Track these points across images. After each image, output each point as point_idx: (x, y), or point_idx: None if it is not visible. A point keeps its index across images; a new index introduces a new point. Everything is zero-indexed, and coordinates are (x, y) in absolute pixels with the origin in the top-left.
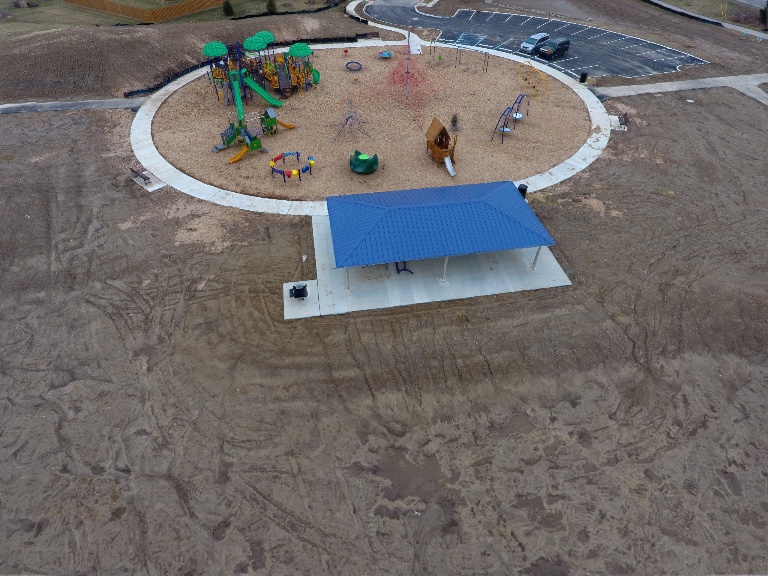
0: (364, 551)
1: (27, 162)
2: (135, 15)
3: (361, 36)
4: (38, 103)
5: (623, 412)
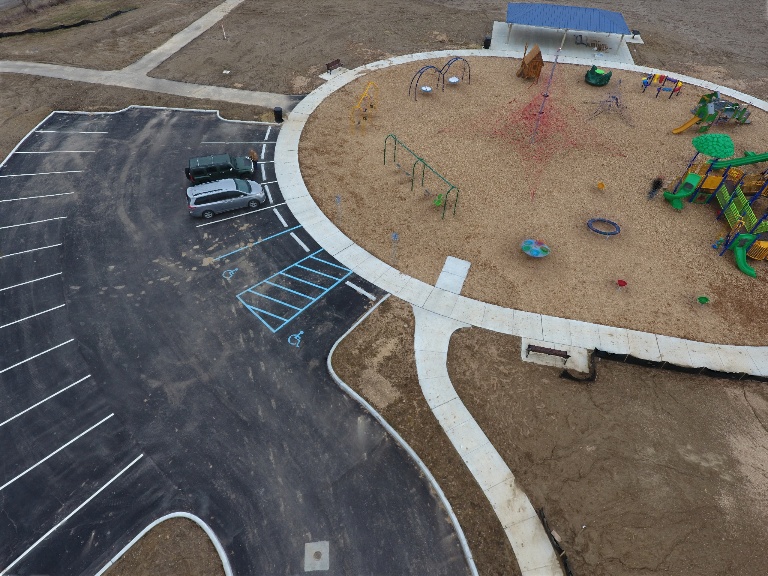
0: (601, 8)
1: None
2: None
3: (579, 381)
4: None
5: None
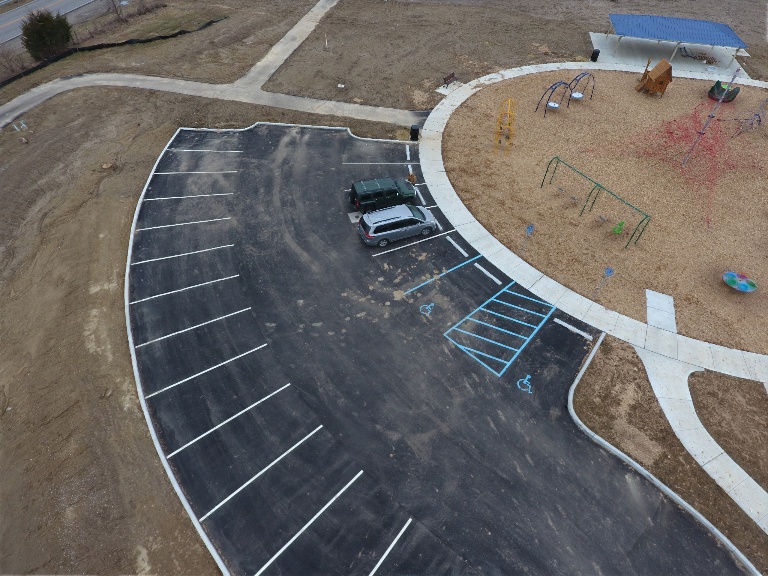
0: None
1: None
2: None
3: None
4: None
5: None
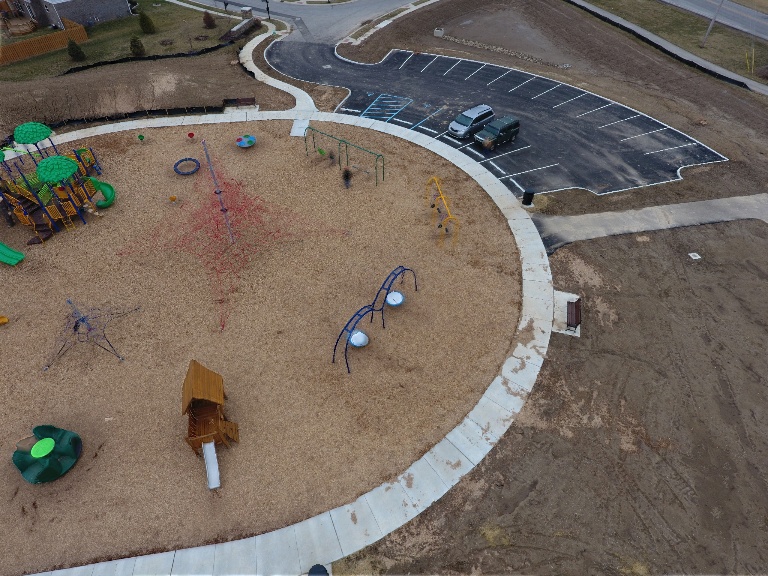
0: None
1: None
2: None
3: (232, 102)
4: None
5: None
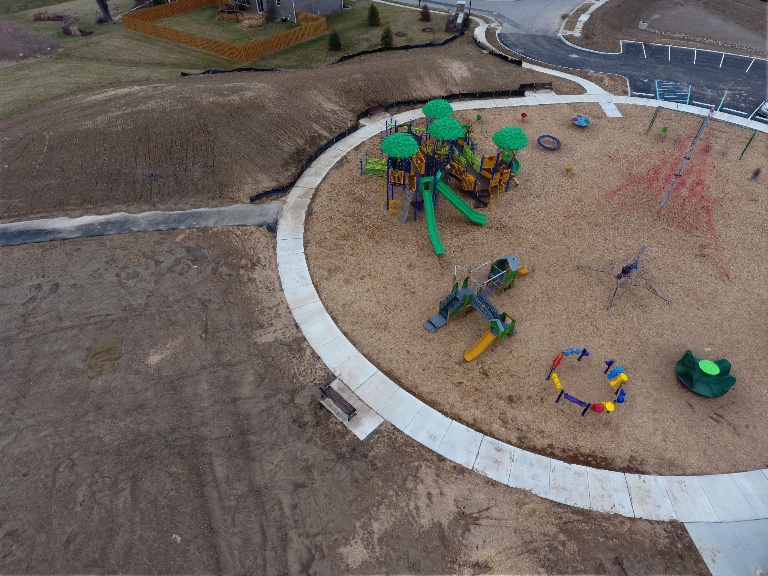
0: None
1: (144, 367)
2: (220, 51)
3: (526, 87)
4: (129, 215)
5: None
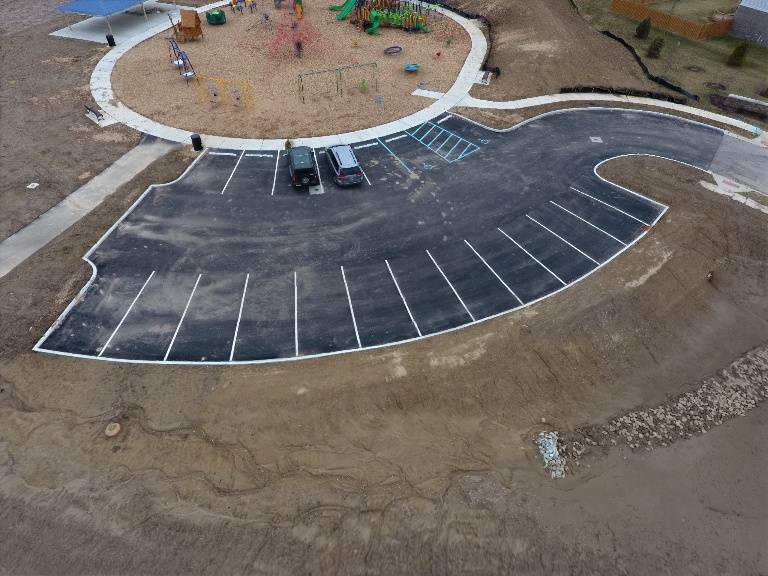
0: None
1: None
2: None
3: (499, 74)
4: None
5: (4, 29)
